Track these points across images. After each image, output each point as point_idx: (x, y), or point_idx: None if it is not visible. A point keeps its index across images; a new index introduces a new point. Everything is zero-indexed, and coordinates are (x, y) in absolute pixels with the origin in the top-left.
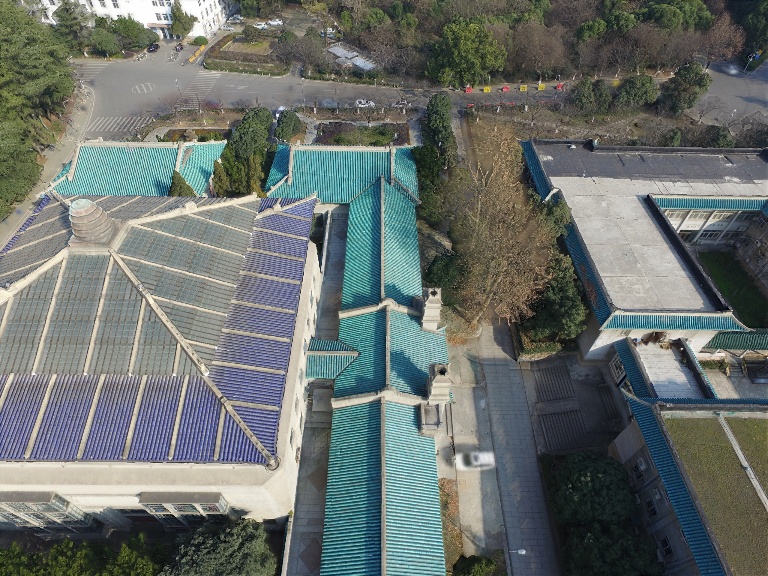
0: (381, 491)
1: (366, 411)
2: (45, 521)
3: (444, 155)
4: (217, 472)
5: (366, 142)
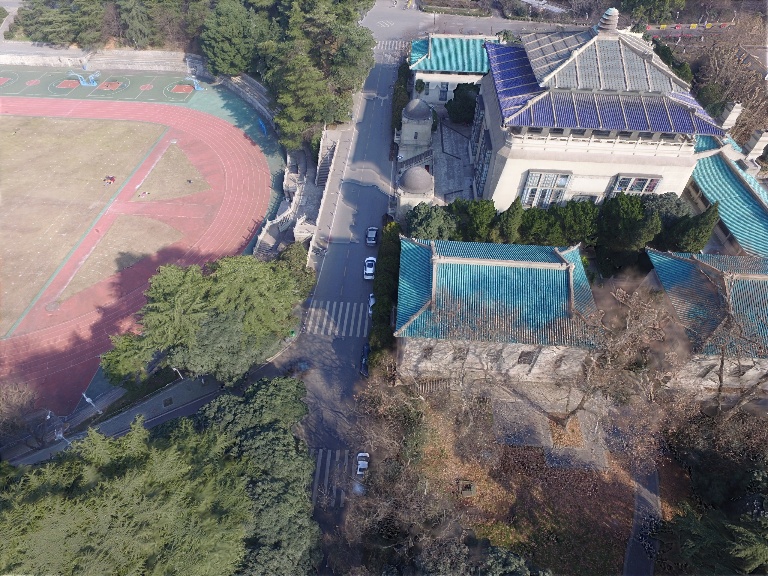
0: (746, 182)
1: (710, 160)
2: (541, 202)
3: None
4: (668, 159)
5: None
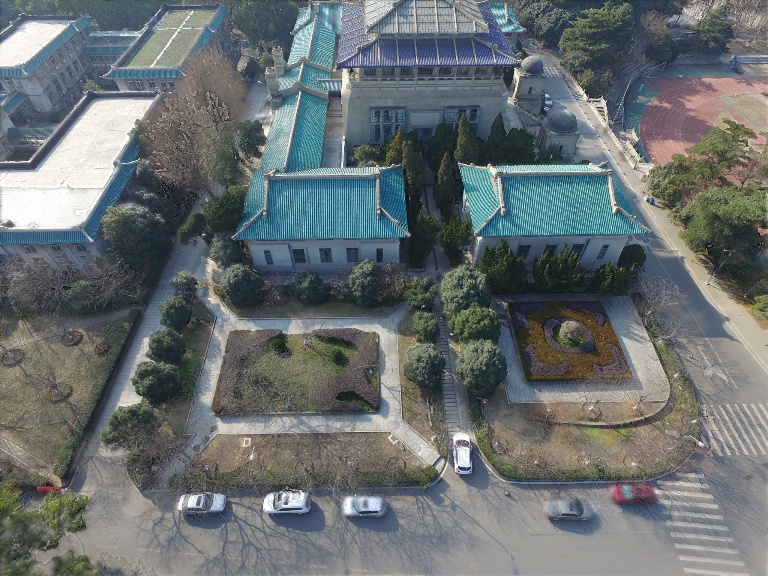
0: None
1: None
2: None
3: (192, 276)
4: None
5: (296, 359)
